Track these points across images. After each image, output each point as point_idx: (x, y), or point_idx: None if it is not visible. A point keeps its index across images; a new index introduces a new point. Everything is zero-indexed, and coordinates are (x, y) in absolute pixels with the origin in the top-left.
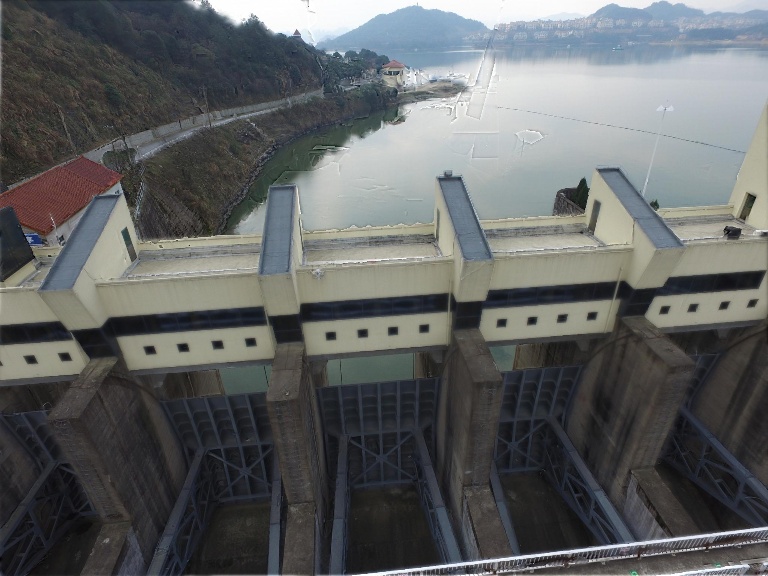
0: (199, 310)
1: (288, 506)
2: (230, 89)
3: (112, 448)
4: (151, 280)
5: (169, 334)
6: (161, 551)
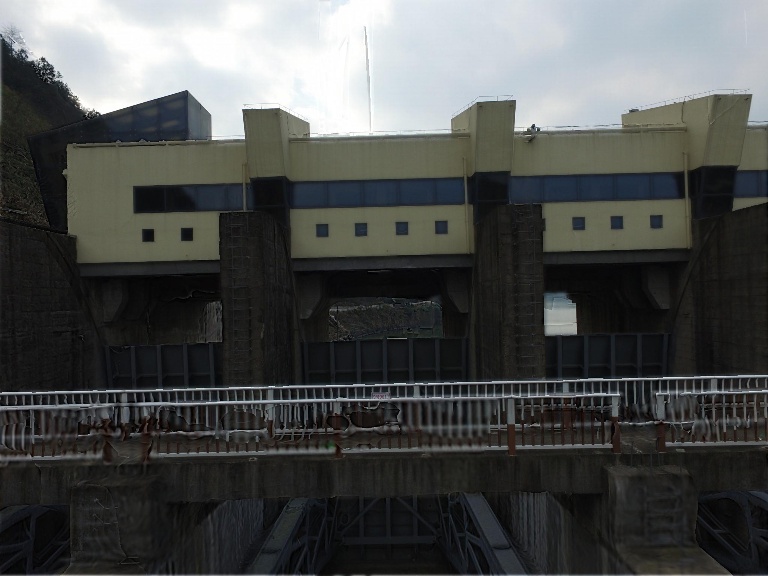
0: (390, 178)
1: None
2: None
3: (270, 302)
4: (347, 137)
5: (349, 209)
6: (293, 509)
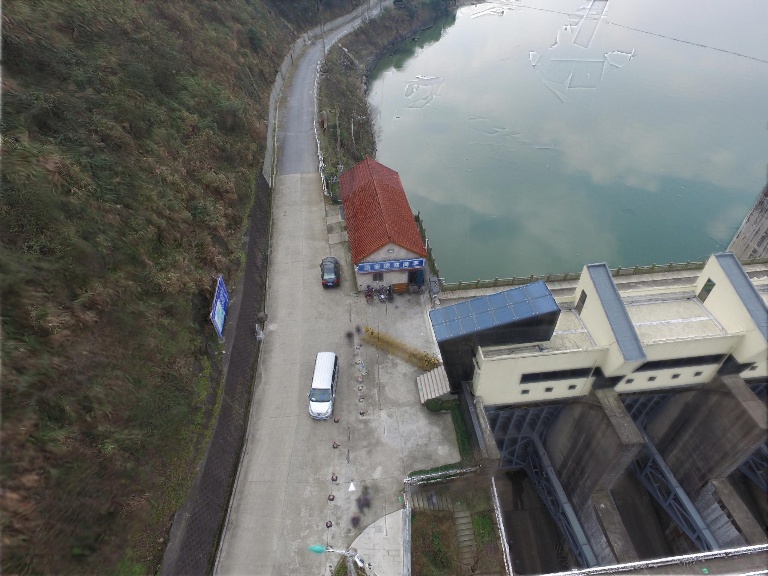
0: (682, 357)
1: (709, 480)
2: (312, 5)
3: None
4: None
5: (650, 372)
6: None
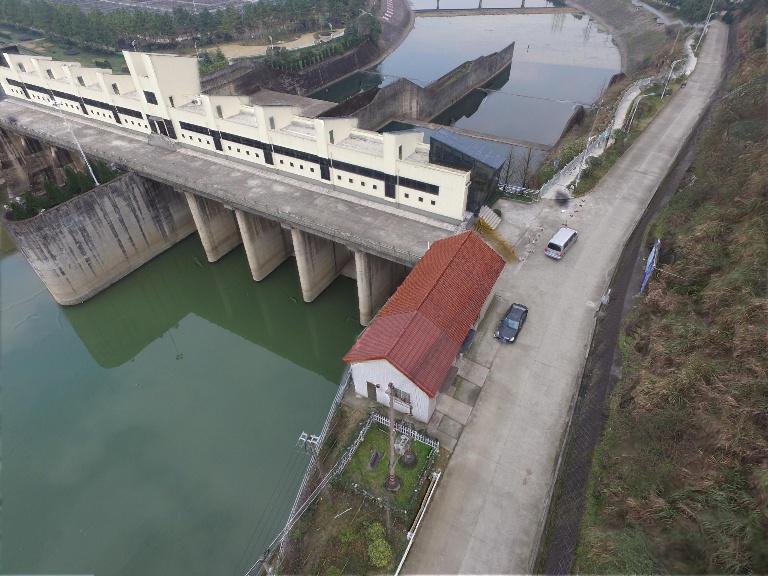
0: None
1: None
2: None
3: None
4: None
5: None
6: None
